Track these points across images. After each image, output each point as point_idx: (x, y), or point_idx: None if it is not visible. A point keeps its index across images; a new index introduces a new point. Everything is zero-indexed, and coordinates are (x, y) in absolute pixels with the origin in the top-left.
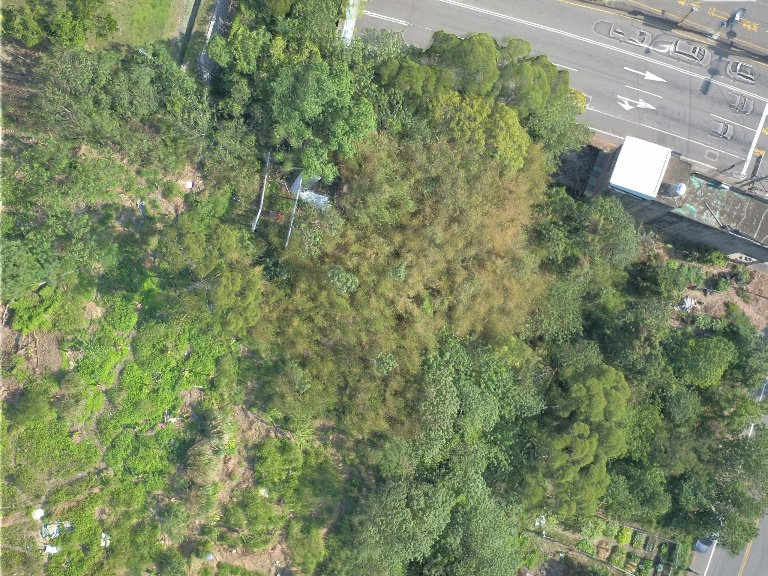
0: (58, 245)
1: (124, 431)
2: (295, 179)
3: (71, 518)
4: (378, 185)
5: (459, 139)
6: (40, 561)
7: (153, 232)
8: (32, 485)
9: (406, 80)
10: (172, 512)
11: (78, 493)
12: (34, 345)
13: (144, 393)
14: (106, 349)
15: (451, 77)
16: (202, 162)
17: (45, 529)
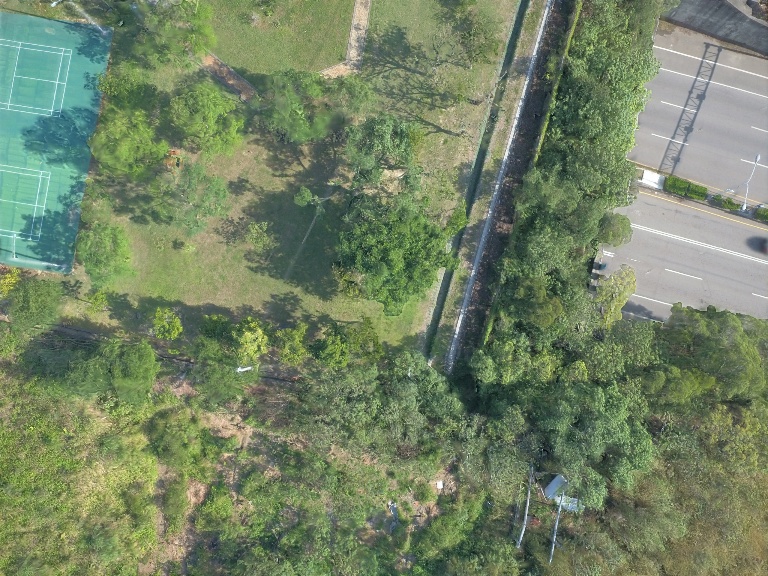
0: (310, 547)
1: None
2: (549, 482)
3: None
4: (657, 519)
5: (732, 461)
6: None
7: (406, 535)
8: None
9: (675, 396)
10: None
11: None
12: None
13: None
14: None
15: (712, 381)
16: (454, 463)
17: None
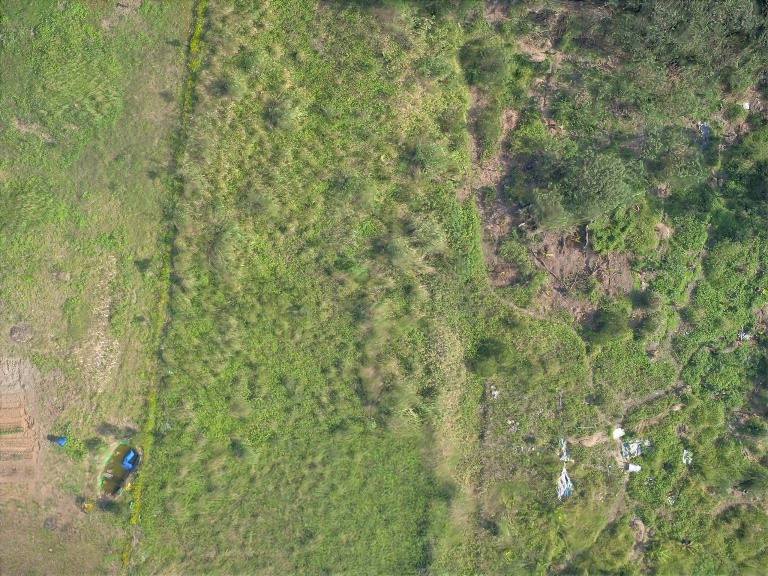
0: None
1: (700, 349)
2: None
3: (655, 436)
4: None
5: None
6: (622, 480)
7: (717, 153)
8: (613, 405)
9: None
10: (757, 427)
11: (659, 411)
12: (606, 267)
13: (721, 311)
14: (681, 268)
15: None
16: (761, 83)
17: (626, 448)
